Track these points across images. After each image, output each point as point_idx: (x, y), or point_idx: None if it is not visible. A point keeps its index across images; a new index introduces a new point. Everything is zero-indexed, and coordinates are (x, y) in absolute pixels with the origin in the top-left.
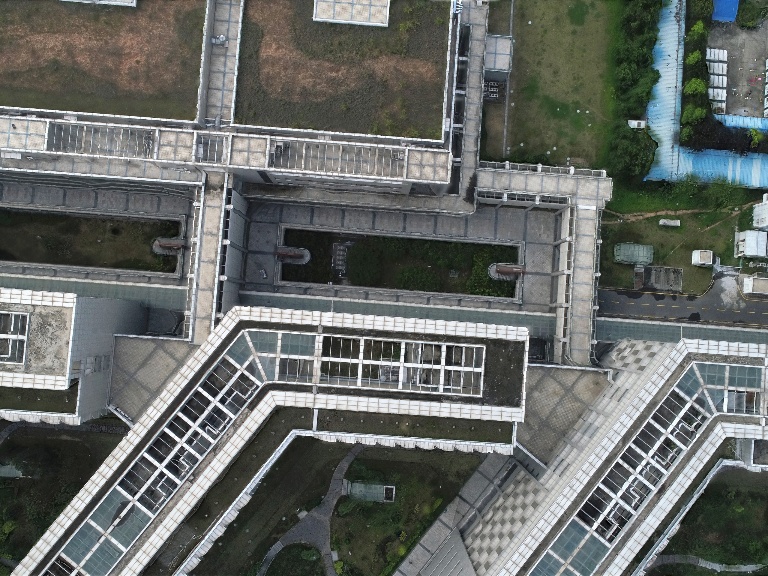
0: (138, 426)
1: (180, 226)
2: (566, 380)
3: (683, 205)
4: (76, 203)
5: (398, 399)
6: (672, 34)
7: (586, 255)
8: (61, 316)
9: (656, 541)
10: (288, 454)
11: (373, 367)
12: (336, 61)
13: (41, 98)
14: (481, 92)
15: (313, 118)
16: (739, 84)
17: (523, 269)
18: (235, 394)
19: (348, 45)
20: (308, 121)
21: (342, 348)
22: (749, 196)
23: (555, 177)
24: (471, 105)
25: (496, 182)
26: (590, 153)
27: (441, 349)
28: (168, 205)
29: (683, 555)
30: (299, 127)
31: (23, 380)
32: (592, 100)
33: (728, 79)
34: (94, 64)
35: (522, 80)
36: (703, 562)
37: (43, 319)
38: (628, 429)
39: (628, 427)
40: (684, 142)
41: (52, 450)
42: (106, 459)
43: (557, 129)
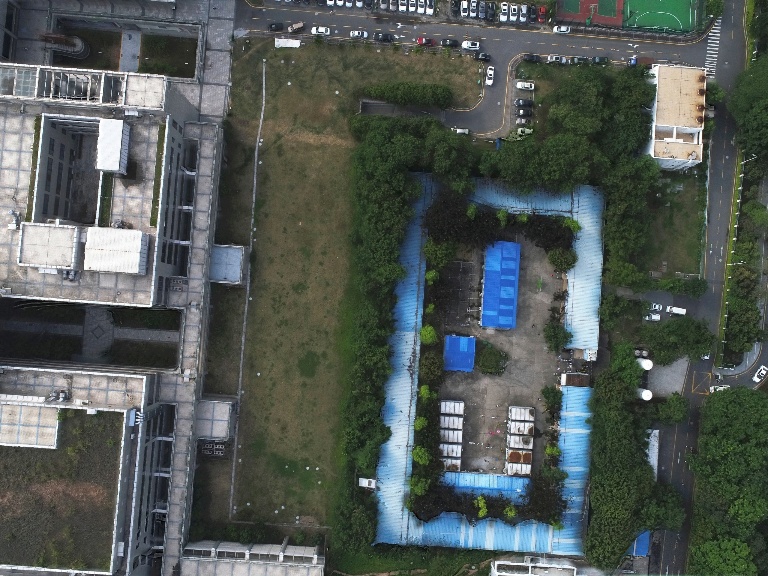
0: None
1: None
2: None
3: (417, 564)
4: None
5: None
6: (405, 388)
7: None
8: None
9: None
10: None
11: None
12: (1, 487)
13: None
14: (186, 475)
15: None
16: (480, 432)
17: None
18: None
19: (15, 469)
20: None
21: None
22: (487, 553)
23: (263, 565)
24: (176, 489)
25: (201, 571)
26: (320, 512)
27: None
28: None
29: None
30: None
31: None
32: (322, 457)
33: (469, 427)
34: None
35: (249, 436)
36: None
37: None
38: None
39: None
40: None
41: None
42: None
43: (285, 488)
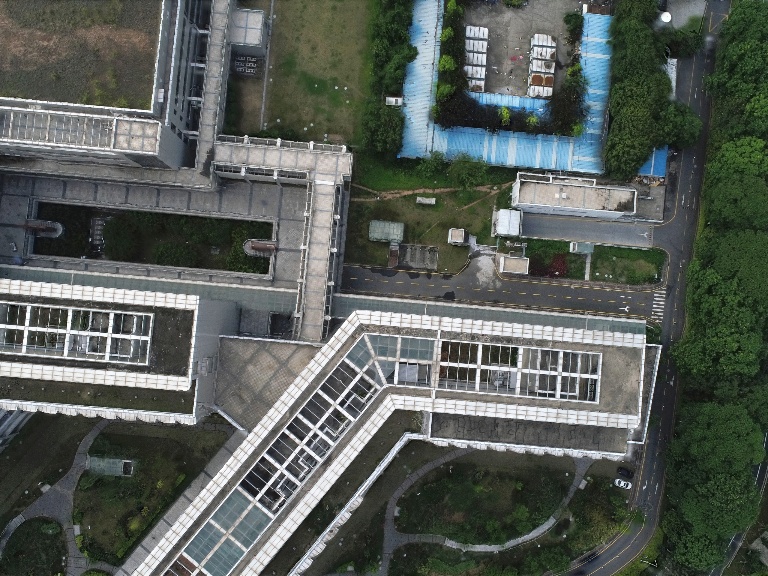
0: None
1: None
2: (281, 354)
3: (441, 183)
4: None
5: (63, 366)
6: (431, 11)
7: (323, 230)
8: None
9: (337, 514)
10: (32, 428)
11: (39, 334)
12: (47, 30)
13: None
14: (221, 65)
15: (23, 87)
16: (503, 63)
17: (276, 245)
18: None
19: (61, 14)
20: (18, 90)
21: (9, 315)
22: (508, 175)
23: (294, 152)
24: (211, 78)
25: (234, 156)
26: (348, 130)
27: (109, 317)
28: None
29: (430, 534)
30: (8, 96)
31: None
32: (350, 76)
33: (492, 57)
34: None
35: (280, 56)
36: (449, 542)
37: None
38: (296, 400)
39: (296, 398)
40: (436, 119)
41: None
42: None
43: (314, 105)
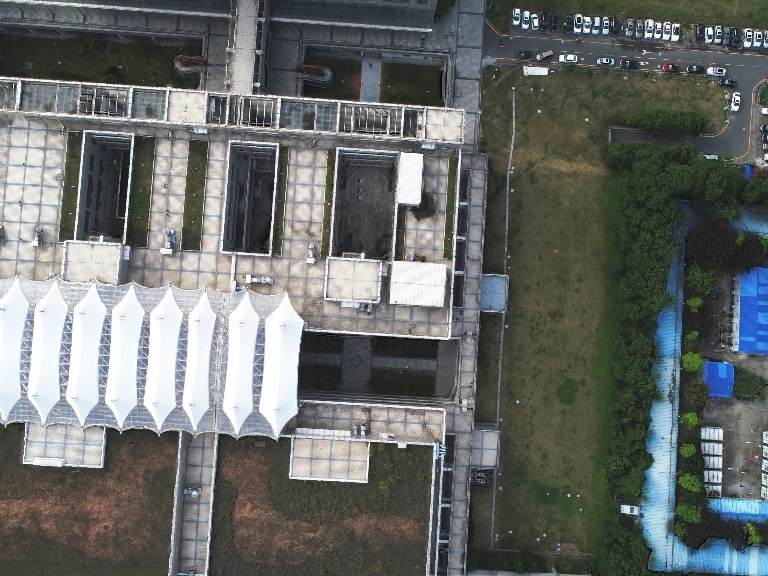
0: None
1: None
2: None
3: None
4: None
5: None
6: (665, 415)
7: None
8: None
9: None
10: None
11: None
12: (314, 521)
13: (5, 568)
14: (467, 506)
15: None
16: (735, 457)
17: None
18: None
19: (326, 503)
20: None
21: None
22: None
23: None
24: (457, 519)
25: None
26: (581, 539)
27: None
28: None
29: None
30: None
31: None
32: (583, 484)
33: (724, 453)
34: (60, 531)
35: (510, 463)
36: None
37: None
38: None
39: None
40: None
41: None
42: None
43: (547, 515)
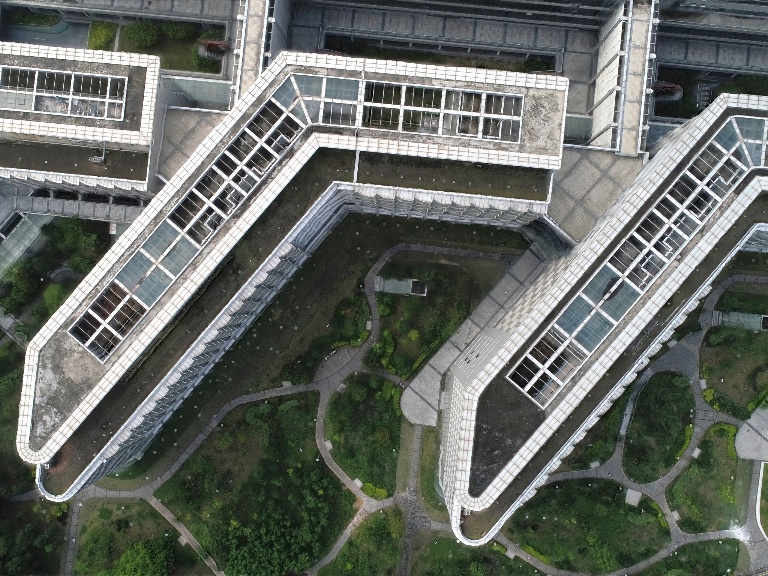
0: (628, 206)
1: (552, 62)
2: None
3: None
4: (455, 35)
5: None
6: None
7: None
8: (554, 99)
9: None
10: None
11: None
12: None
13: None
14: None
15: None
16: None
17: None
18: (717, 180)
19: None
20: None
21: None
22: None
23: None
24: None
25: None
26: None
27: None
28: (544, 39)
29: None
30: None
31: (518, 159)
32: None
33: None
34: None
35: None
36: None
37: (536, 101)
38: None
39: None
40: None
41: (444, 268)
42: (597, 236)
43: None
